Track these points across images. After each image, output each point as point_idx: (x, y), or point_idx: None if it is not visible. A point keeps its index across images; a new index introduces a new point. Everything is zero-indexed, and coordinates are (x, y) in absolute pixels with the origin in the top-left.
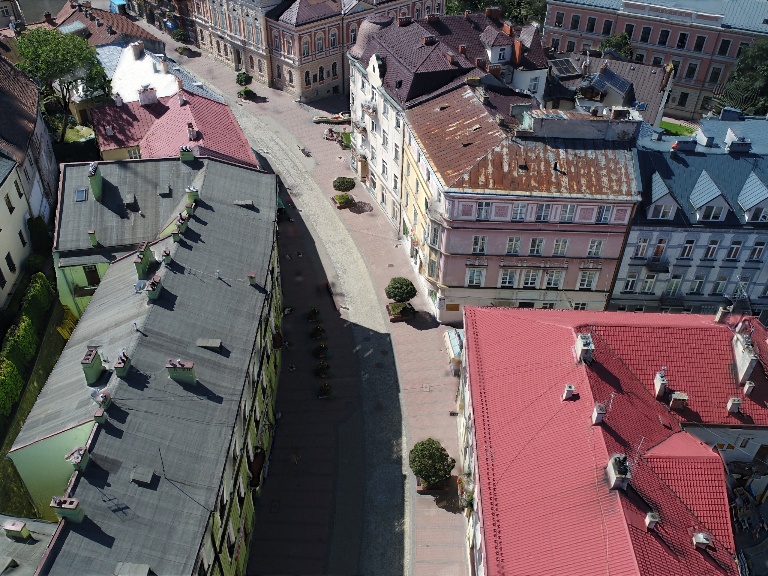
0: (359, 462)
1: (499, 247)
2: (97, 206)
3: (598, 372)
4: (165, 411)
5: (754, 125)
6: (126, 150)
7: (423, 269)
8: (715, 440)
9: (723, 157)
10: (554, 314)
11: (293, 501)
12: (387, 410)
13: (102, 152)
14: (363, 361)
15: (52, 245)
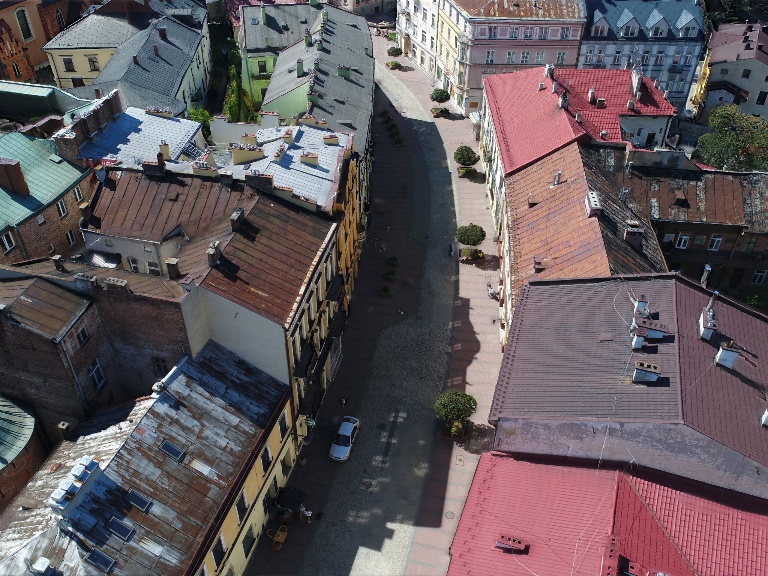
0: (424, 168)
1: (502, 58)
2: (265, 27)
3: None
4: (340, 84)
5: None
6: None
7: (455, 82)
8: (623, 128)
9: (638, 1)
10: None
11: (389, 180)
12: (437, 150)
13: (235, 27)
14: (419, 133)
15: (225, 66)
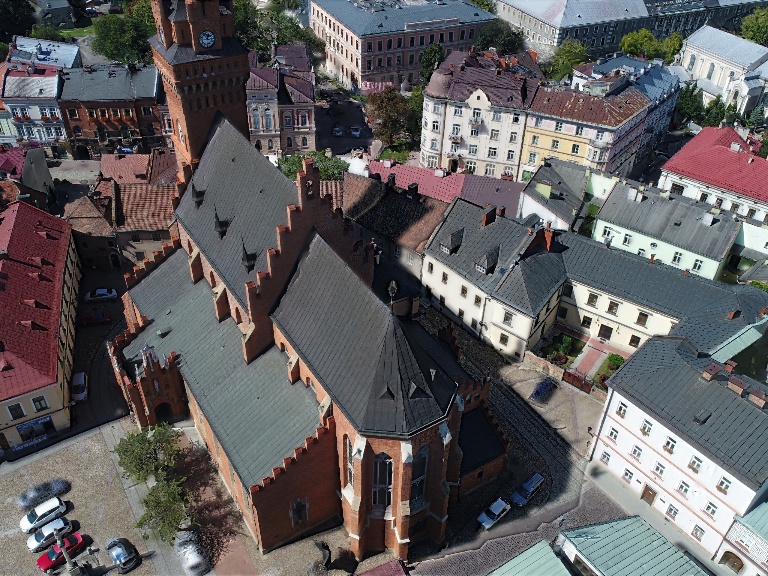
0: None
1: None
2: (553, 201)
3: None
4: None
5: (614, 62)
6: None
7: None
8: None
9: (643, 76)
10: (687, 152)
11: None
12: None
13: None
14: None
15: None
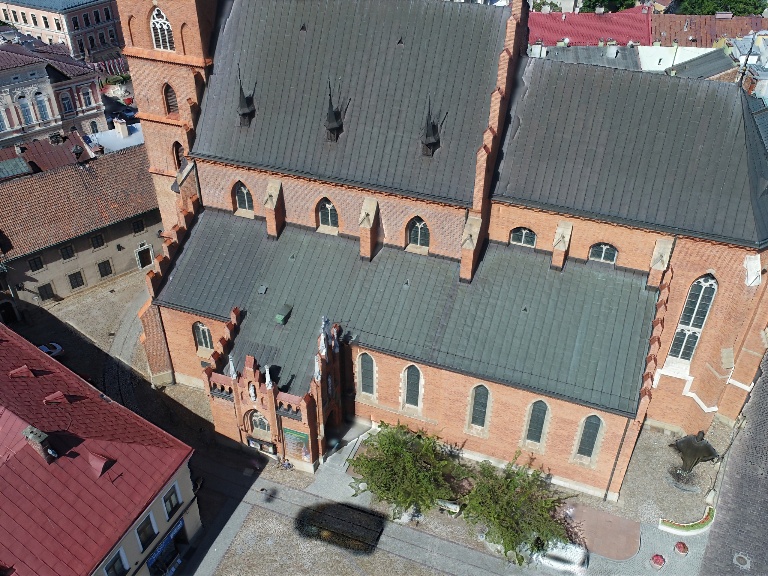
0: None
1: None
2: None
3: None
4: None
5: None
6: None
7: None
8: None
9: None
10: None
11: None
12: None
13: None
14: None
15: None
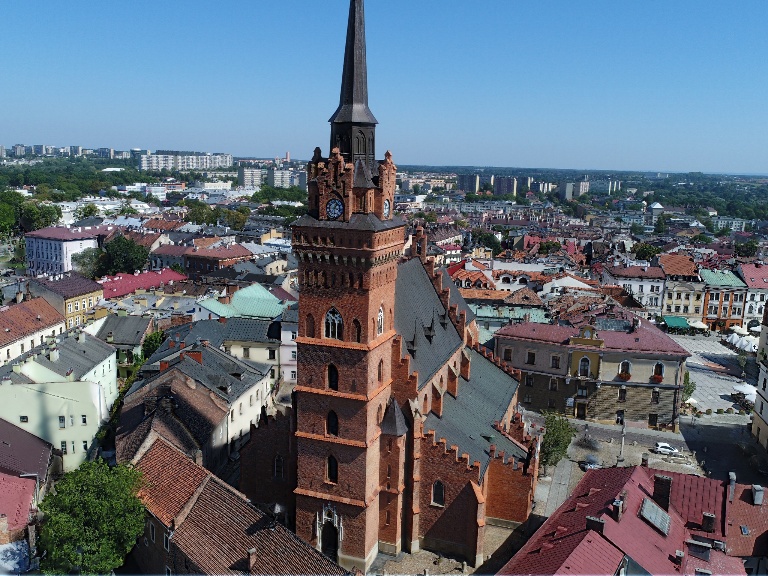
0: None
1: None
2: None
3: None
4: None
5: None
6: None
7: None
8: None
9: None
10: None
11: None
12: None
13: None
14: None
15: None
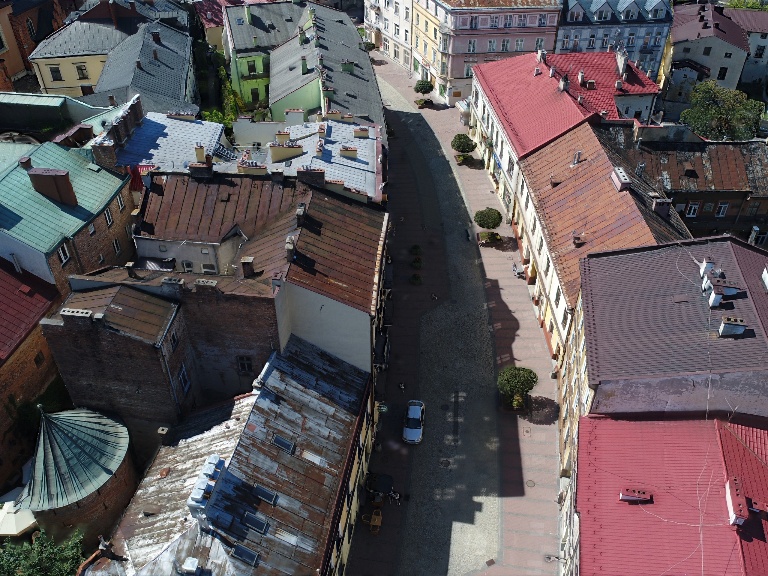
0: (421, 158)
1: (484, 47)
2: (251, 27)
3: (550, 67)
4: (346, 79)
5: None
6: (221, 28)
7: (437, 72)
8: None
9: None
10: None
11: (391, 172)
12: (430, 140)
13: (207, 29)
14: (409, 124)
15: (208, 68)
